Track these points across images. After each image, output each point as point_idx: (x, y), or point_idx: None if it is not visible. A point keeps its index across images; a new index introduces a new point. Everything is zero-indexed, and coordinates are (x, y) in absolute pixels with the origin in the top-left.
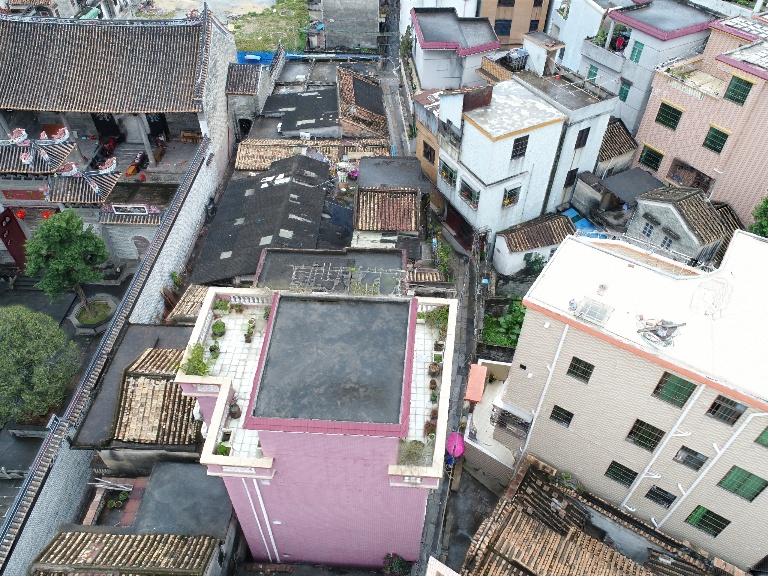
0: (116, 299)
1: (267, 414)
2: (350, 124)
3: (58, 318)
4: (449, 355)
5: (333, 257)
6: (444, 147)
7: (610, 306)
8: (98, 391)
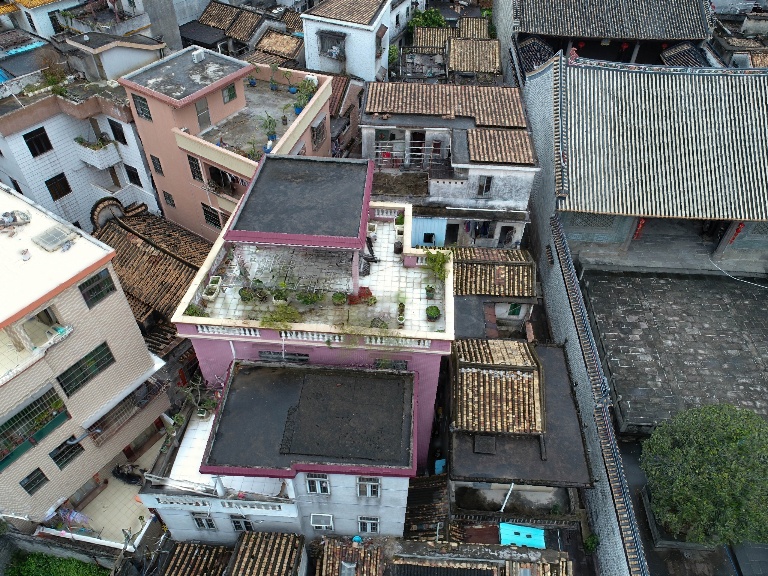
0: None
1: (359, 168)
2: None
3: None
4: (205, 266)
5: (311, 459)
6: None
7: (31, 245)
8: (573, 395)
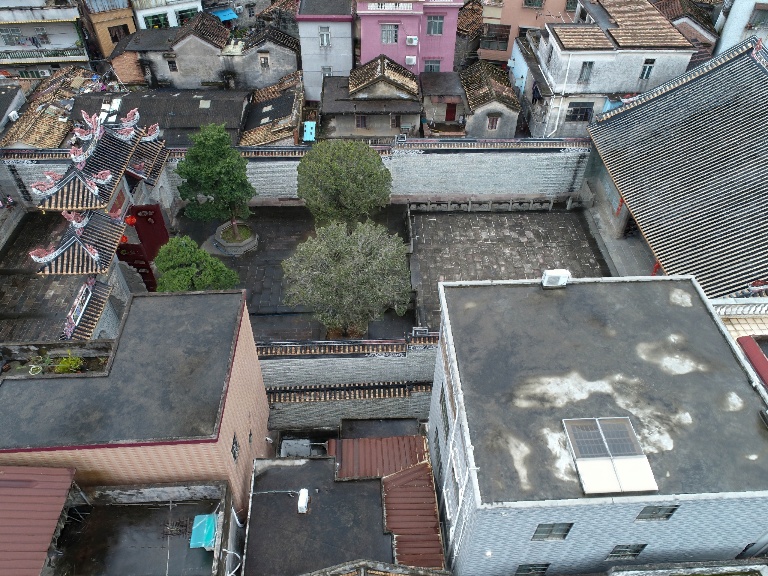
0: (211, 236)
1: None
2: (23, 81)
3: (235, 263)
4: None
5: (304, 1)
6: (145, 5)
7: None
8: None
